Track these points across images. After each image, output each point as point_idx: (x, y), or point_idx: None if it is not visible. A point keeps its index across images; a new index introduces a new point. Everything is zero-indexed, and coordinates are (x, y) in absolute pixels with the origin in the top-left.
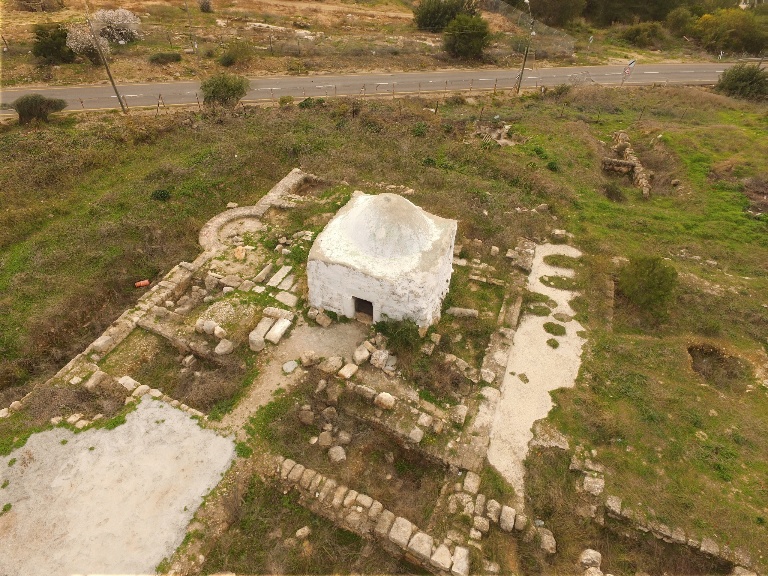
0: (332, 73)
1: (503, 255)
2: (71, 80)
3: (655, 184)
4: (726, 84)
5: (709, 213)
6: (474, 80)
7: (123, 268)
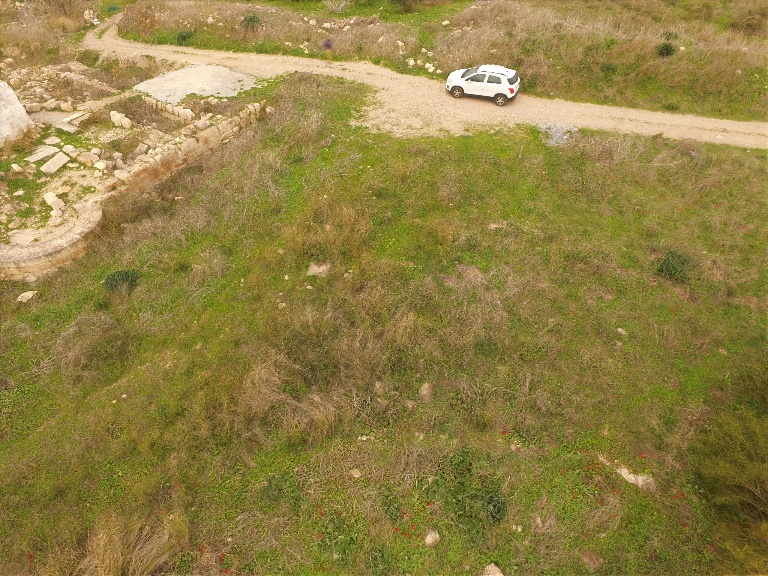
0: None
1: None
2: None
3: None
4: None
5: None
6: None
7: None
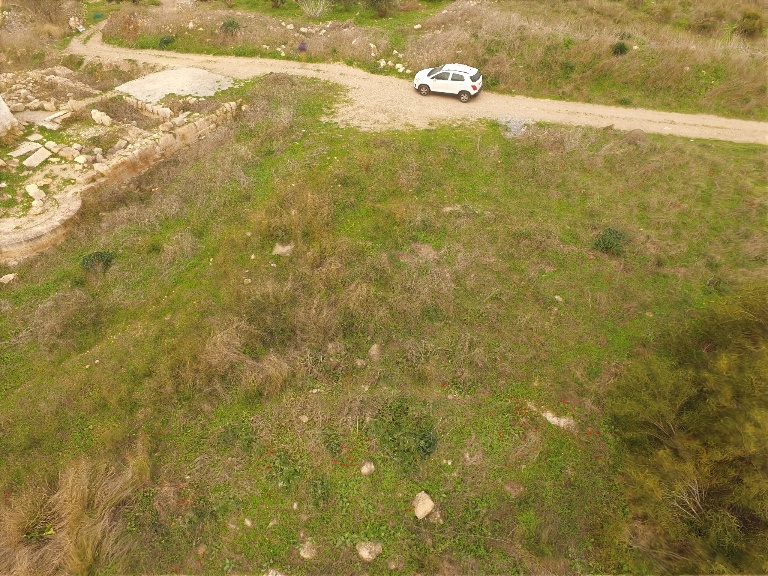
0: None
1: None
2: None
3: None
4: None
5: None
6: None
7: None
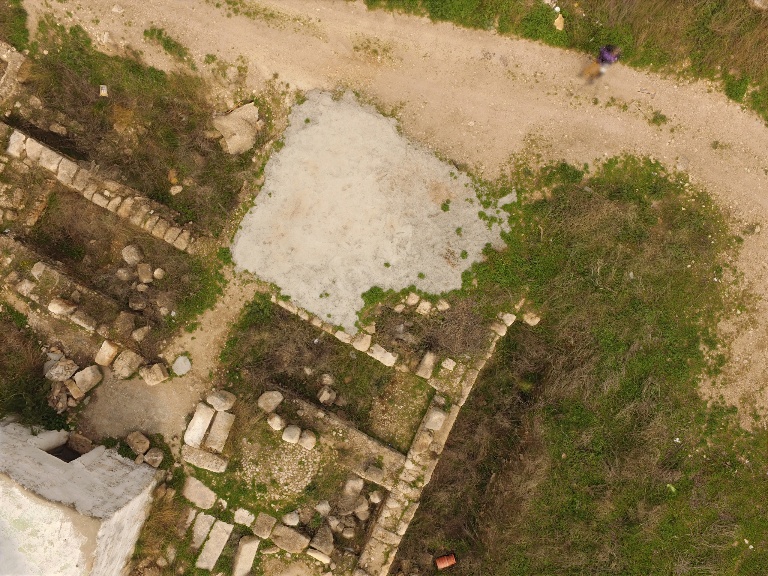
0: None
1: None
2: None
3: None
4: None
5: None
6: None
7: None
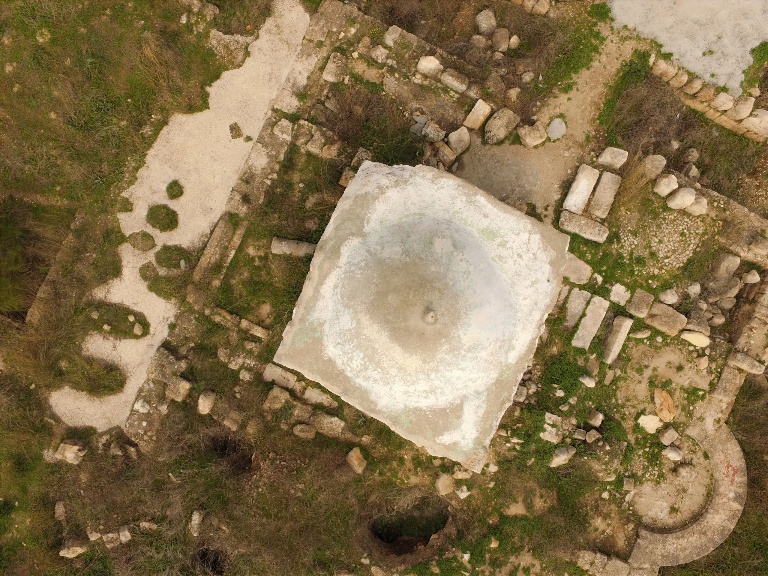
0: None
1: (194, 391)
2: None
3: None
4: None
5: None
6: None
7: None
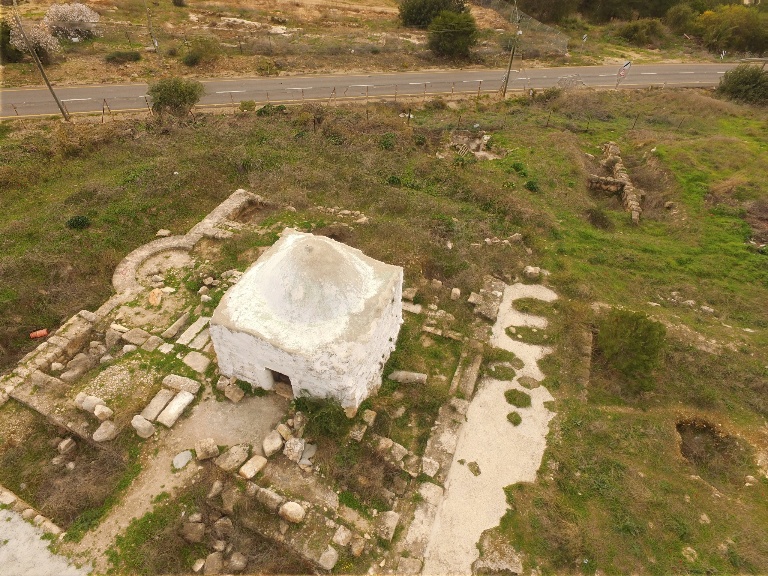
0: (305, 74)
1: (465, 299)
2: (16, 81)
3: (647, 206)
4: (728, 87)
5: (706, 244)
6: (458, 82)
7: (17, 315)
